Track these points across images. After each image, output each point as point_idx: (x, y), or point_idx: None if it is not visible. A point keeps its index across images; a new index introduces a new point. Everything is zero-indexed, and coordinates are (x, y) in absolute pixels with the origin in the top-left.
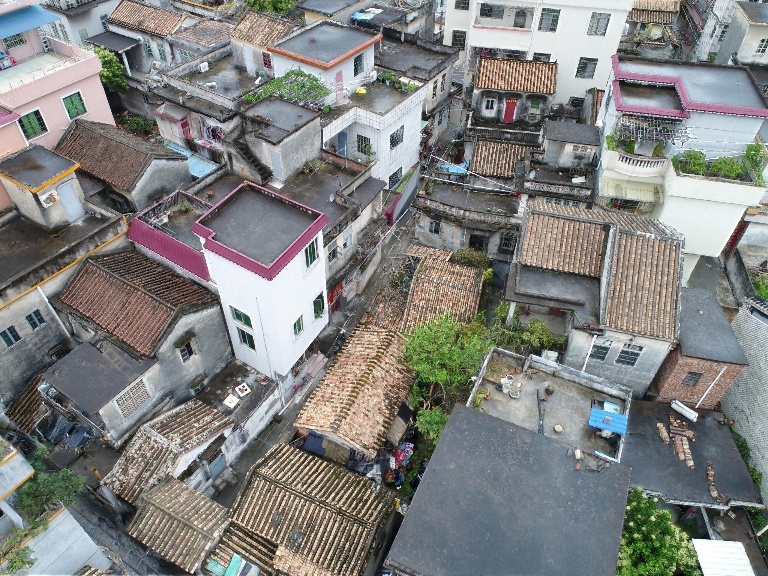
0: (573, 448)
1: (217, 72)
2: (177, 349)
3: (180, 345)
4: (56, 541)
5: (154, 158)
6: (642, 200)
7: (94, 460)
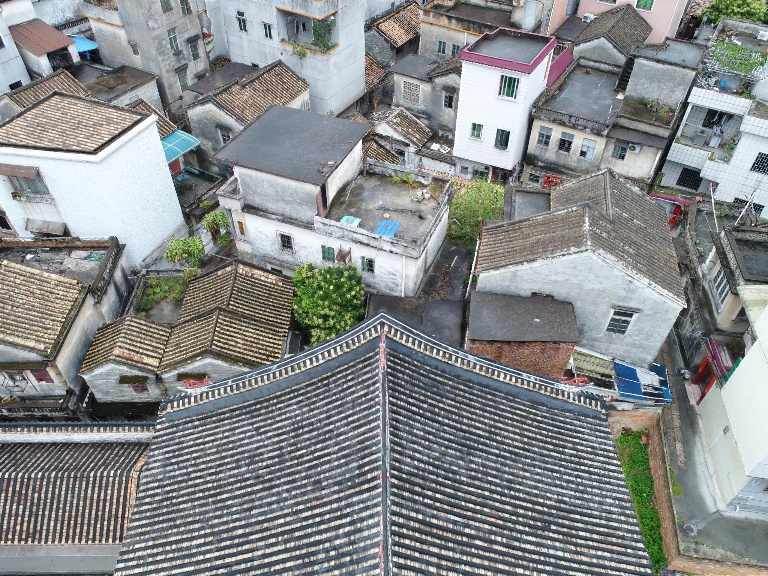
0: (337, 164)
1: (766, 45)
2: (444, 92)
3: (444, 89)
4: (315, 68)
5: (605, 37)
6: (753, 326)
7: (387, 109)
